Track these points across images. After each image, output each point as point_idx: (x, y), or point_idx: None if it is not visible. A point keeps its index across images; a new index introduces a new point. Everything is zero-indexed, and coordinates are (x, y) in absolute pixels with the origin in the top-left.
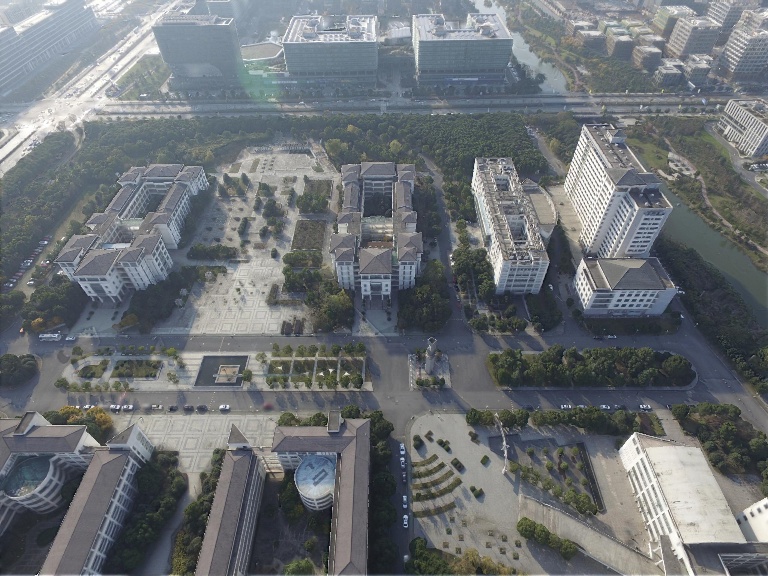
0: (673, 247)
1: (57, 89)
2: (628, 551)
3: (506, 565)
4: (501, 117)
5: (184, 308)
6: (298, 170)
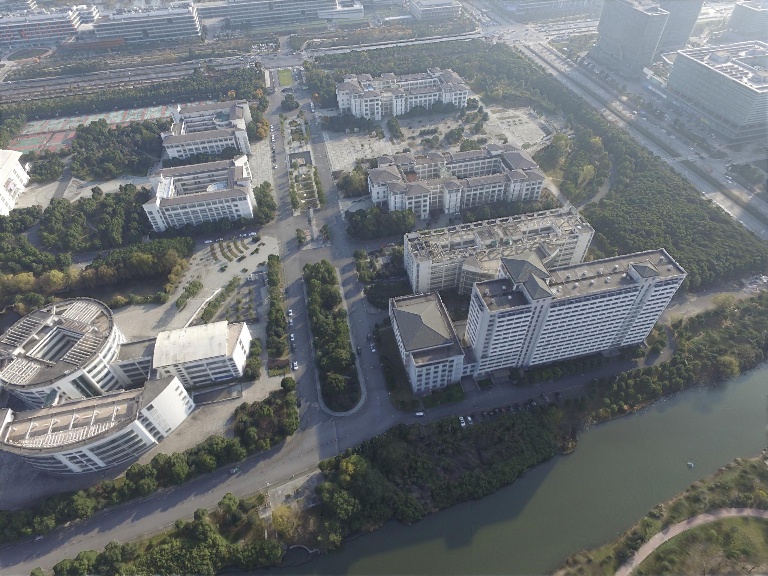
0: (547, 421)
1: (543, 23)
2: None
3: (181, 284)
4: (742, 239)
5: (345, 135)
6: (518, 137)
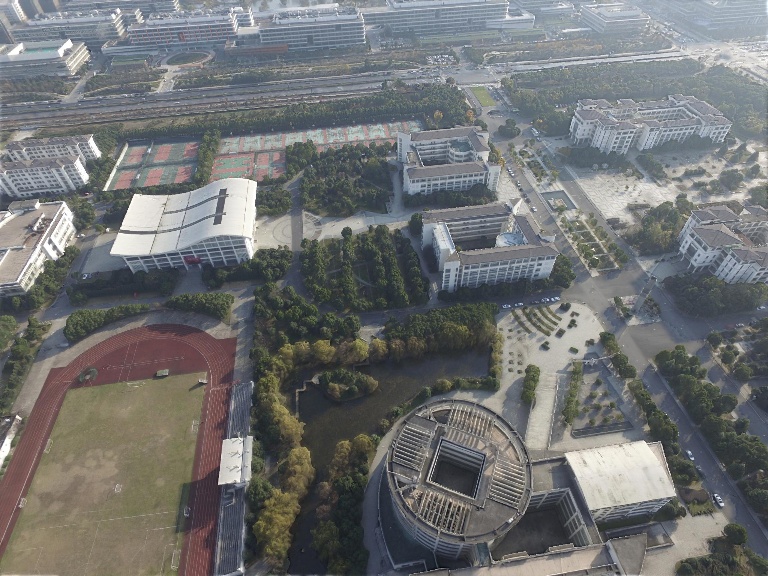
0: None
1: (746, 41)
2: (546, 441)
3: (503, 364)
4: None
5: (593, 171)
6: None
